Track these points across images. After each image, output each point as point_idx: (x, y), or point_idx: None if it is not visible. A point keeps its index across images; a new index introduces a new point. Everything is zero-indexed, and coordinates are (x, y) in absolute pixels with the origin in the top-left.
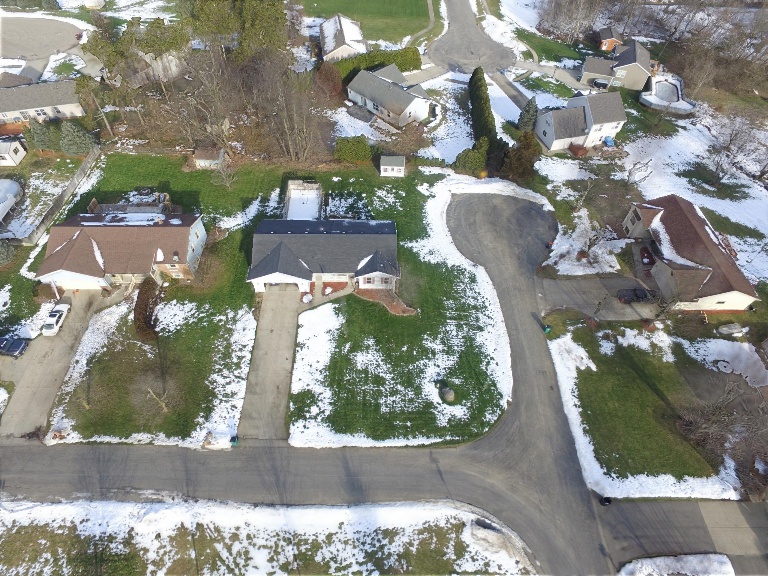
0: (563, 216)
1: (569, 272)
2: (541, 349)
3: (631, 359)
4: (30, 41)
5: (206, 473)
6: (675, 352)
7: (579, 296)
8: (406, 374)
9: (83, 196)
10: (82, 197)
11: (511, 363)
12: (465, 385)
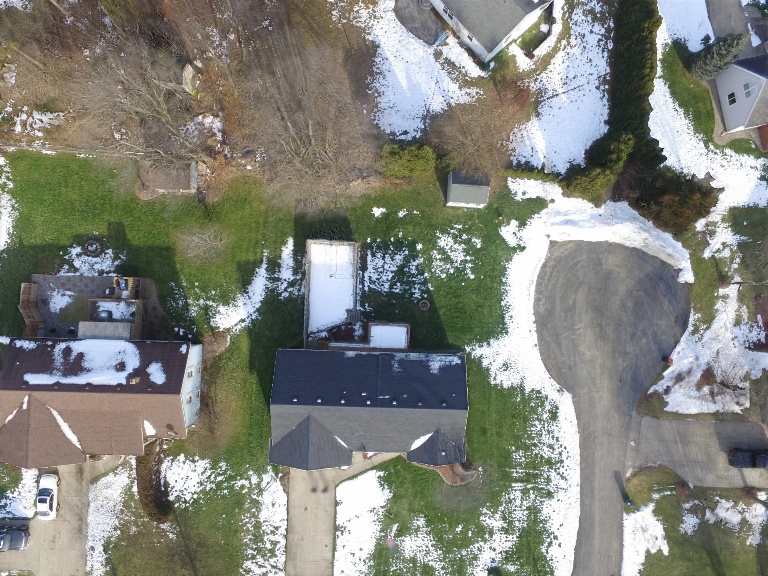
0: (702, 296)
1: (680, 409)
2: (614, 526)
3: (711, 541)
4: None
5: None
6: (765, 532)
7: (681, 448)
8: (458, 562)
9: (3, 258)
10: (2, 260)
11: (576, 544)
12: (520, 573)
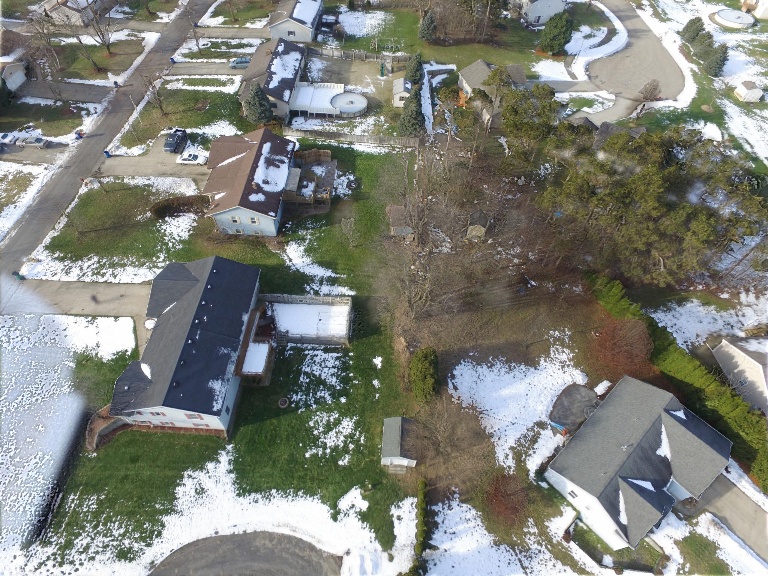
0: None
1: None
2: None
3: None
4: (628, 74)
5: (6, 263)
6: None
7: None
8: (6, 426)
9: (348, 148)
10: (347, 148)
11: None
12: None
